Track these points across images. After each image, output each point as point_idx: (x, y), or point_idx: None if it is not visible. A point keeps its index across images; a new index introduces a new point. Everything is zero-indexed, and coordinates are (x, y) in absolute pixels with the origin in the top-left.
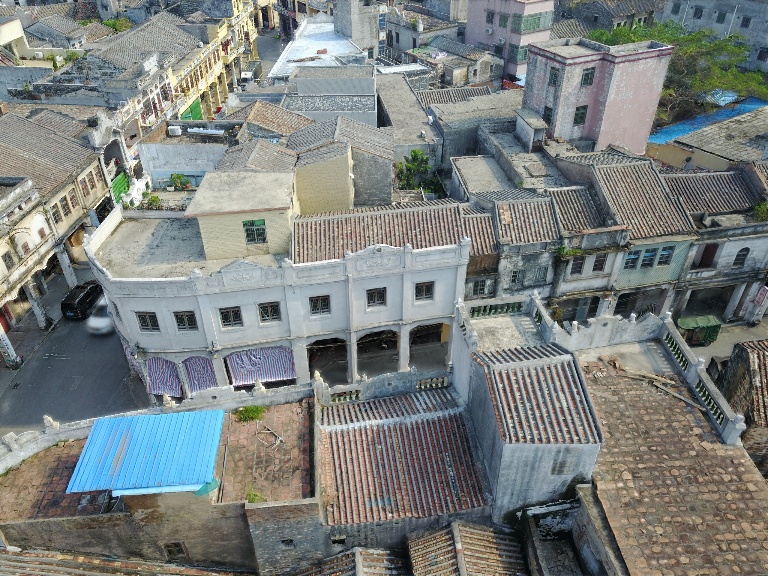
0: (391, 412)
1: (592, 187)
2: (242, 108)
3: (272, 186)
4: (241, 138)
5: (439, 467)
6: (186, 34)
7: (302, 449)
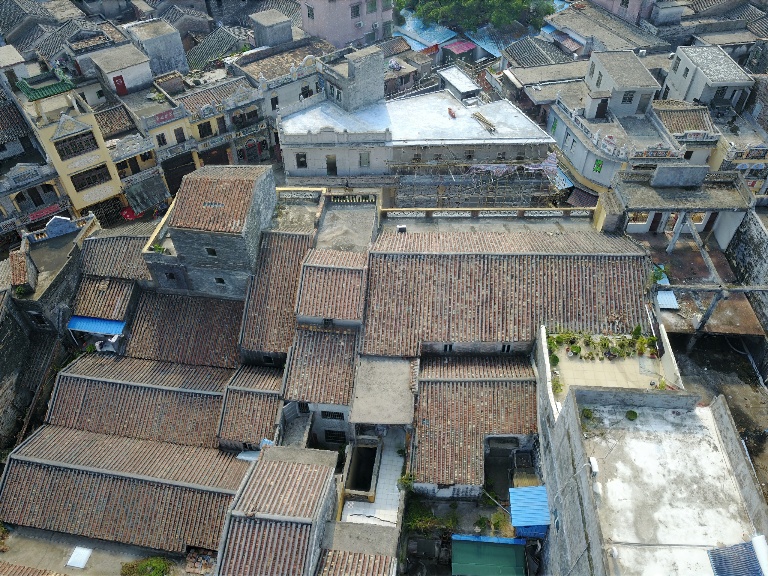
0: None
1: (750, 2)
2: None
3: None
4: None
5: None
6: (384, 239)
7: None
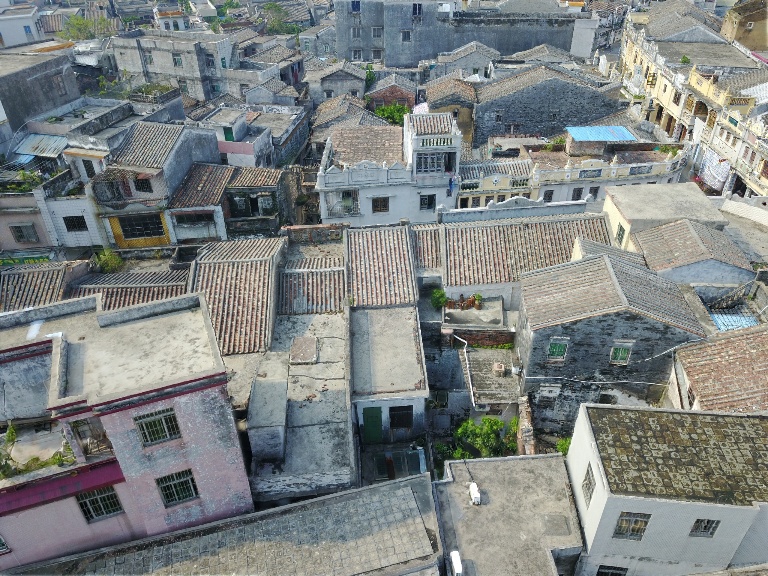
0: (493, 170)
1: None
2: None
3: (638, 204)
4: (763, 295)
5: (467, 163)
6: None
7: (535, 163)
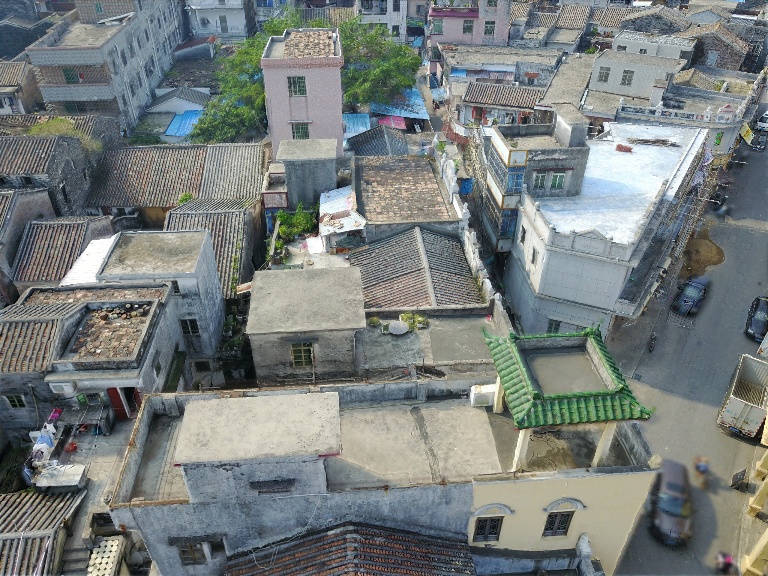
0: None
1: None
2: (726, 39)
3: (699, 2)
4: None
5: None
6: None
7: None
